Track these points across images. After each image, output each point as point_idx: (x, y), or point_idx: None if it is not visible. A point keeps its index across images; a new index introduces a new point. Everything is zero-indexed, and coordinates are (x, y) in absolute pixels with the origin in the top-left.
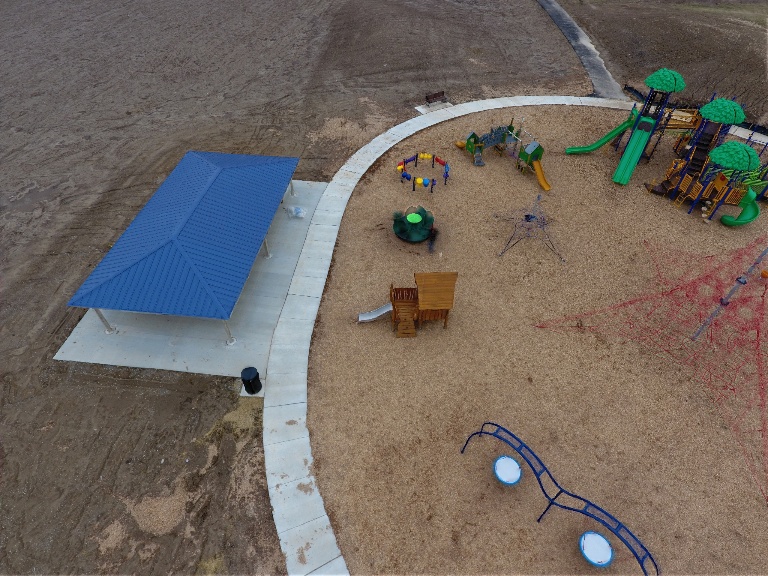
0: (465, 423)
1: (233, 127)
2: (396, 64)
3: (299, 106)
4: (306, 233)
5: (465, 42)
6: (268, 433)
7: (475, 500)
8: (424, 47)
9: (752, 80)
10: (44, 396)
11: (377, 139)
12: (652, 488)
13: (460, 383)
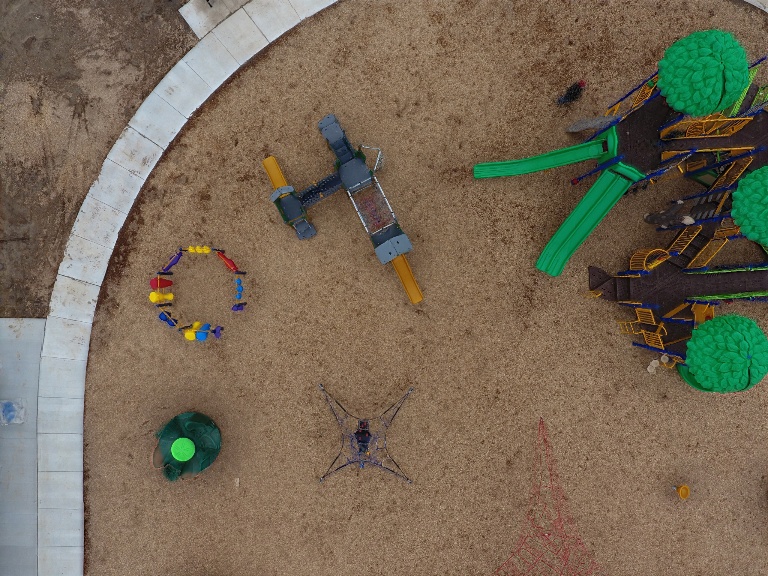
0: None
1: None
2: None
3: None
4: (35, 457)
5: None
6: None
7: None
8: None
9: None
10: None
11: (112, 160)
12: None
13: None
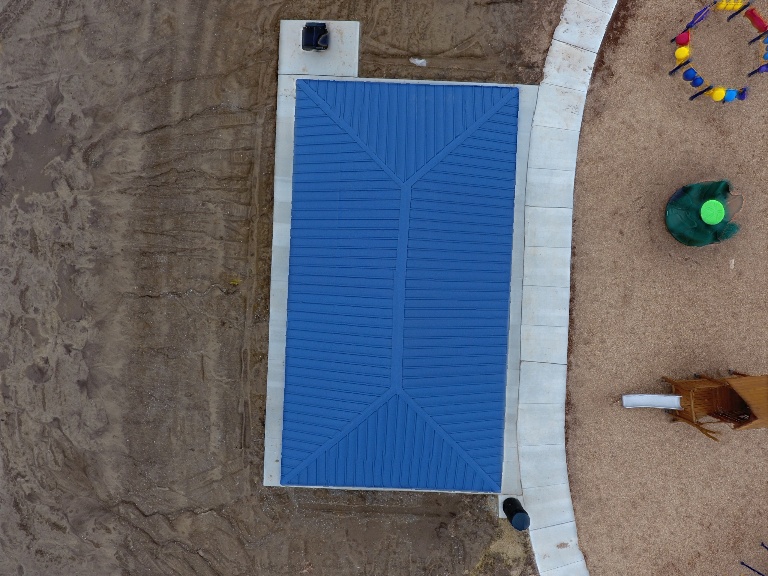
0: (747, 530)
1: None
2: None
3: None
4: (523, 231)
5: None
6: (541, 559)
7: None
8: None
9: None
10: (283, 534)
11: None
12: None
13: (746, 484)
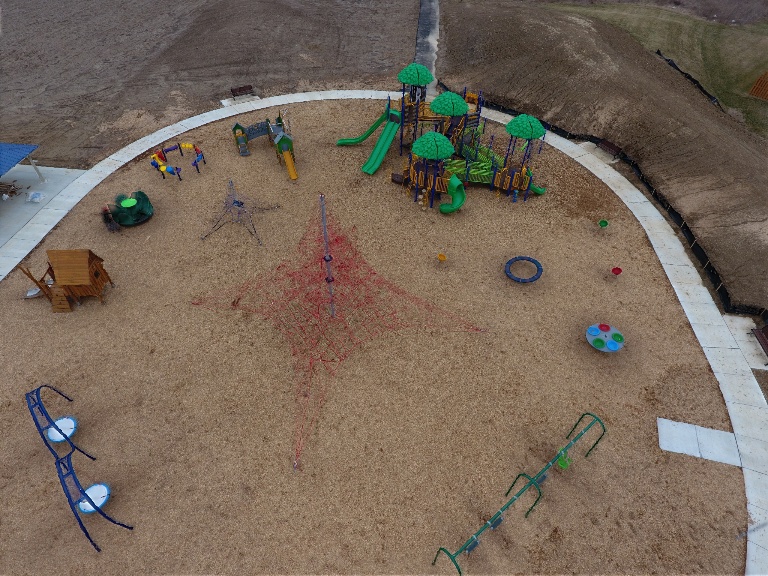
0: (65, 389)
1: (34, 118)
2: (224, 59)
3: (110, 98)
4: (32, 217)
5: (307, 38)
6: None
7: (26, 457)
8: (260, 43)
9: (552, 76)
10: None
11: (163, 130)
12: (197, 448)
13: (84, 354)
